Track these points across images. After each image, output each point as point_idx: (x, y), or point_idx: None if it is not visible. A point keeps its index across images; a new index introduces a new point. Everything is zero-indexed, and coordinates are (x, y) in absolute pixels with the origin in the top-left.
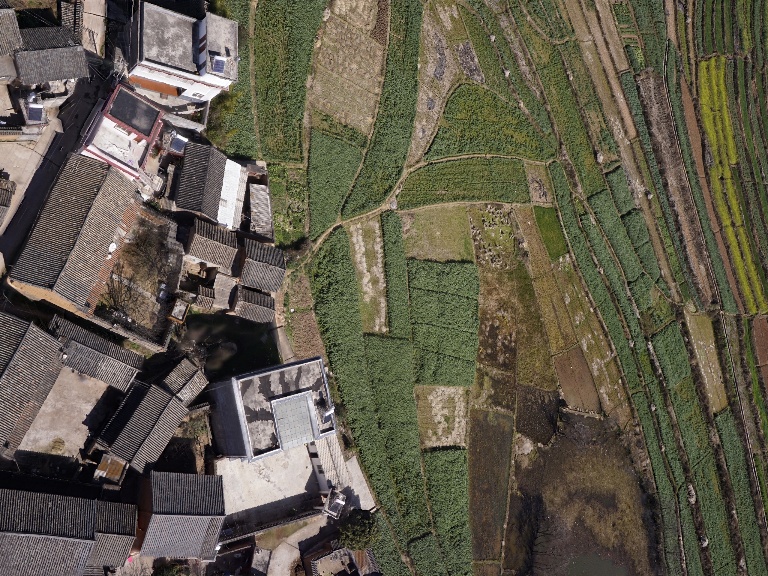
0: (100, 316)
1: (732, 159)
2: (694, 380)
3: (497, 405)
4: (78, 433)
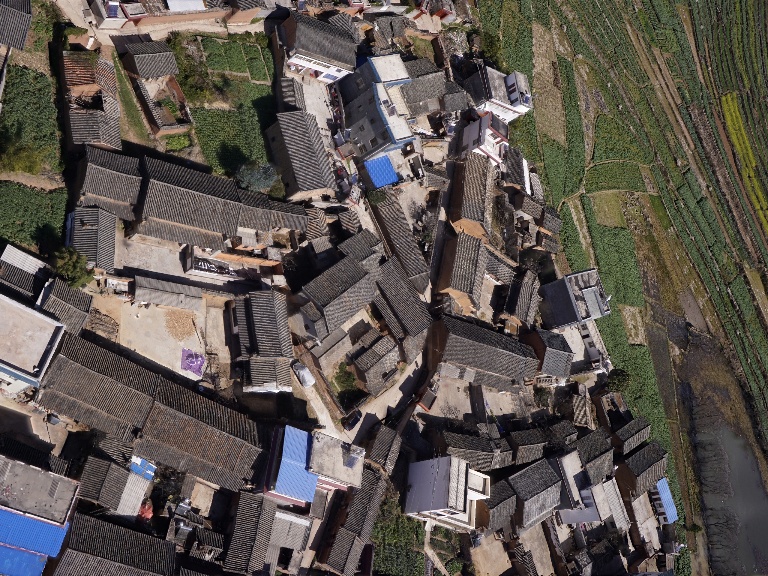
0: (490, 243)
1: (753, 163)
2: (757, 316)
3: (656, 322)
4: (489, 310)
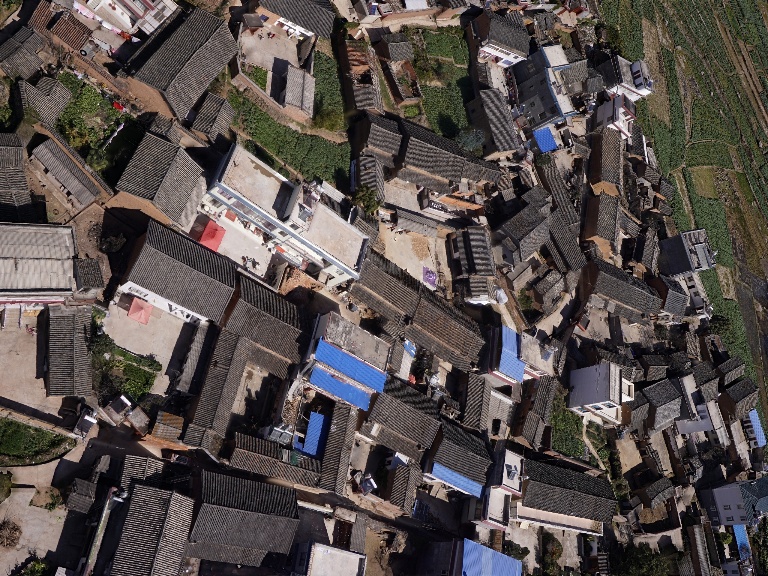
0: None
1: None
2: None
3: (743, 282)
4: (619, 258)
